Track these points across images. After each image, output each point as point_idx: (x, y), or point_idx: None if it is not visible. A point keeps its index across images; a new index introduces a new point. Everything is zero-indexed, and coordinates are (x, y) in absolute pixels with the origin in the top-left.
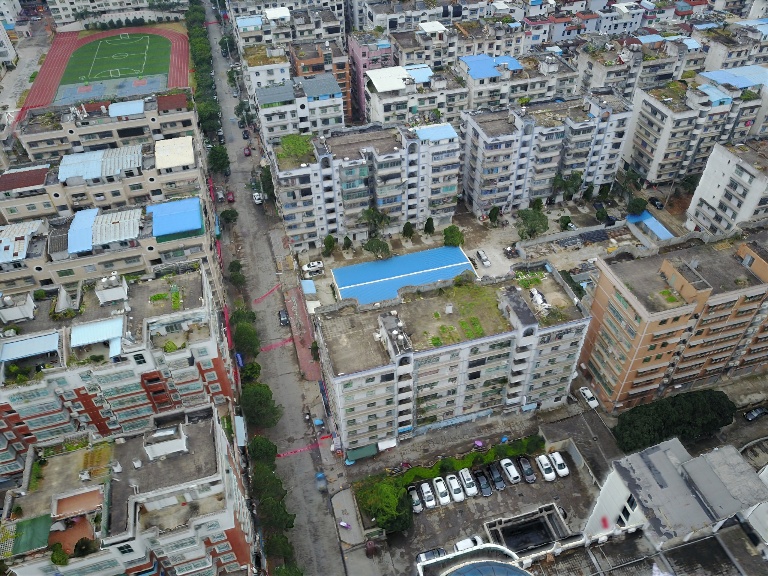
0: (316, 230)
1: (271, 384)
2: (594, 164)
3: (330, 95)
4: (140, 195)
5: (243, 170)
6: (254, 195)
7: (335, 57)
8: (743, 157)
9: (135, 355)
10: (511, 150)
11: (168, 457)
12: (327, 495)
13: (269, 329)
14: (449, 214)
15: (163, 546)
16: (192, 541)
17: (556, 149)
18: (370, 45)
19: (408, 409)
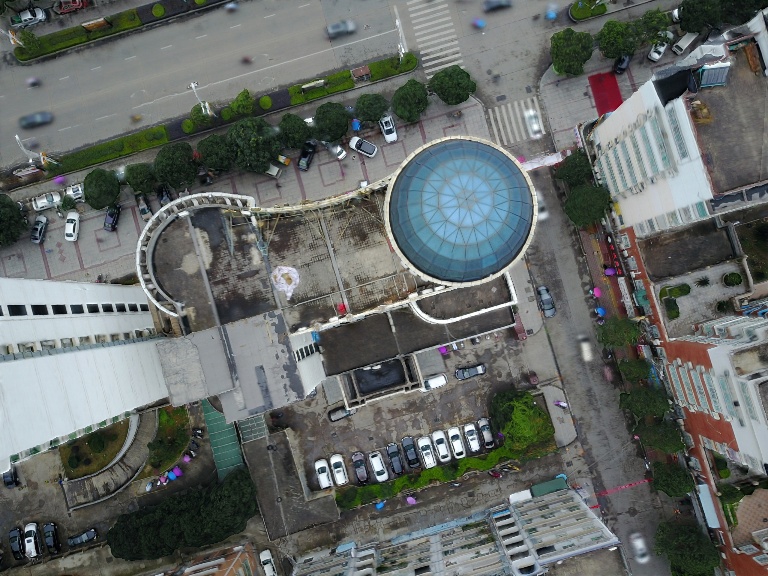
0: None
1: None
2: None
3: None
4: None
5: None
6: None
7: None
8: None
9: None
10: None
11: None
12: (582, 441)
13: None
14: None
15: None
16: None
17: None
18: None
19: None
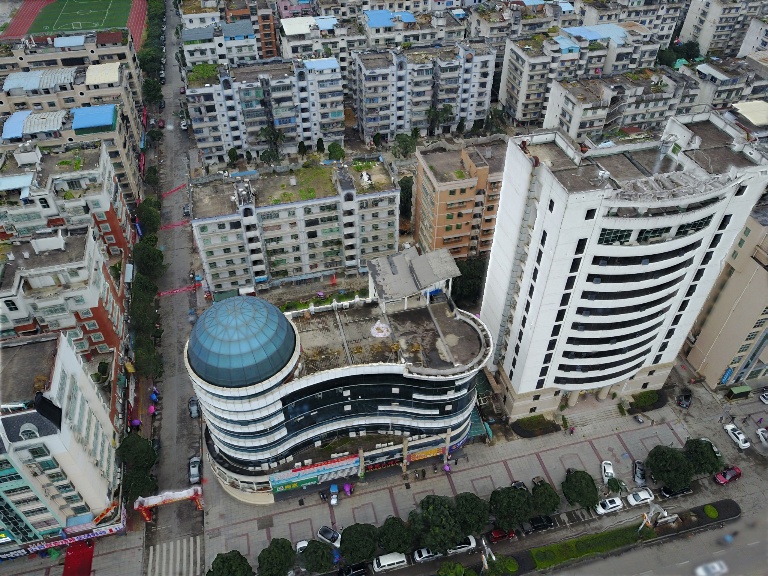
0: (223, 145)
1: (168, 255)
2: (466, 101)
3: (244, 36)
4: None
5: (176, 104)
6: (181, 123)
7: (260, 9)
8: (572, 90)
9: (40, 199)
10: (388, 82)
11: (50, 253)
12: None
13: (174, 218)
14: (339, 138)
15: (40, 309)
16: (63, 309)
17: (428, 84)
18: (291, 0)
19: (261, 261)
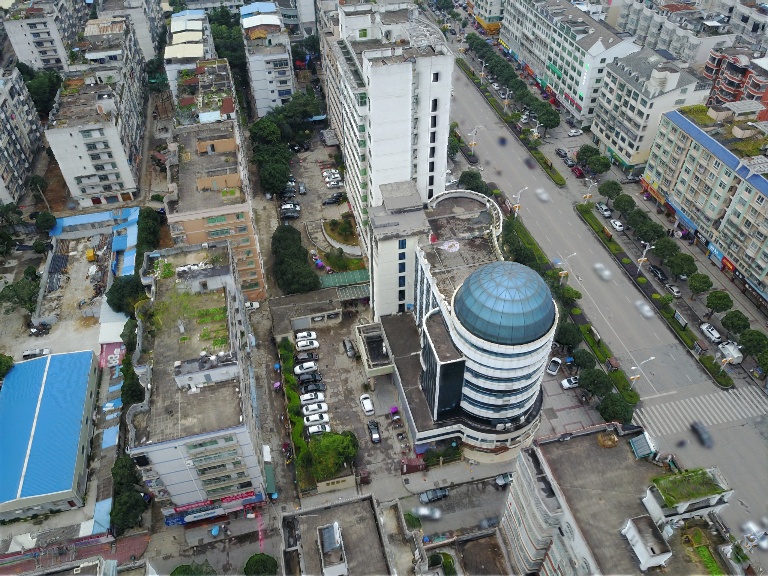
0: None
1: None
2: None
3: None
4: None
5: None
6: None
7: None
8: (74, 125)
9: None
10: None
11: None
12: None
13: None
14: None
15: None
16: None
17: None
18: None
19: None
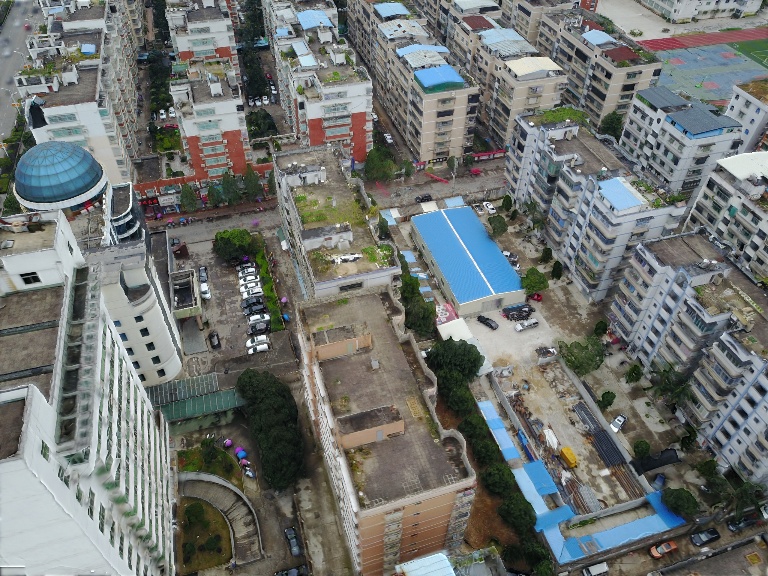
0: (516, 188)
1: None
2: None
3: (685, 130)
4: (495, 76)
5: None
6: None
7: None
8: (732, 570)
9: None
10: (651, 281)
11: None
12: (260, 230)
13: None
14: (586, 288)
15: None
16: None
17: (693, 339)
18: None
19: None
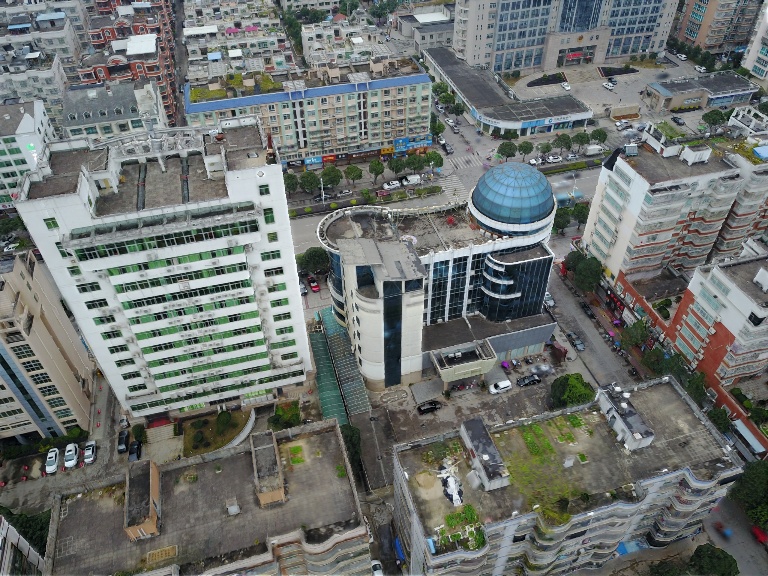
0: None
1: (765, 563)
2: None
3: None
4: None
5: None
6: None
7: None
8: None
9: None
10: None
11: None
12: None
13: None
14: None
15: None
16: None
17: None
18: None
19: None
